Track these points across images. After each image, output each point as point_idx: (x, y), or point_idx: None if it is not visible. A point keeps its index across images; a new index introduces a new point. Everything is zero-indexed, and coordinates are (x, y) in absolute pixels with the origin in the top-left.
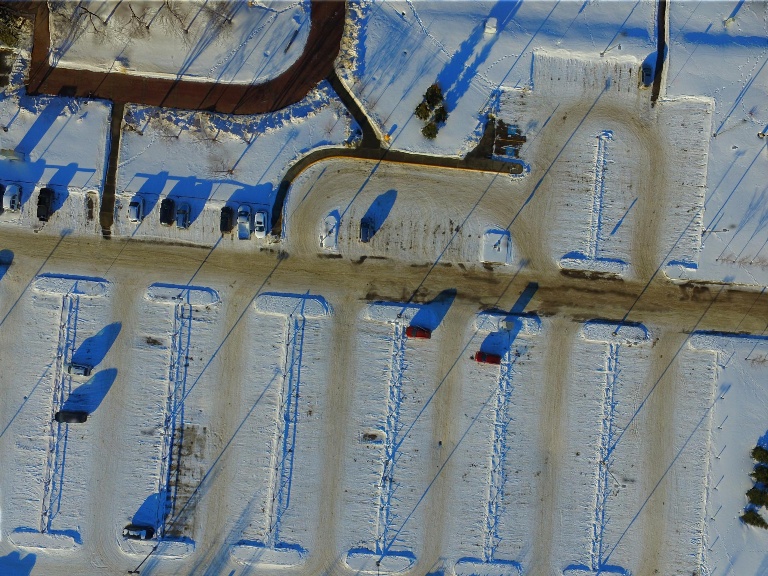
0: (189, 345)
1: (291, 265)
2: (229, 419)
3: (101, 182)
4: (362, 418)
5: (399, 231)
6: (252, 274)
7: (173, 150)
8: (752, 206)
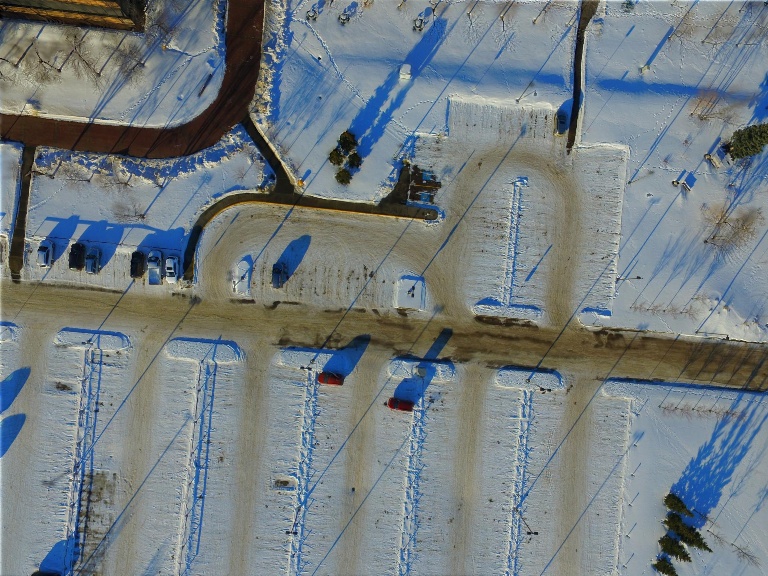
0: (99, 390)
1: (203, 310)
2: (139, 465)
3: (10, 226)
4: (274, 464)
5: (313, 276)
6: (164, 319)
7: (84, 194)
8: (667, 253)
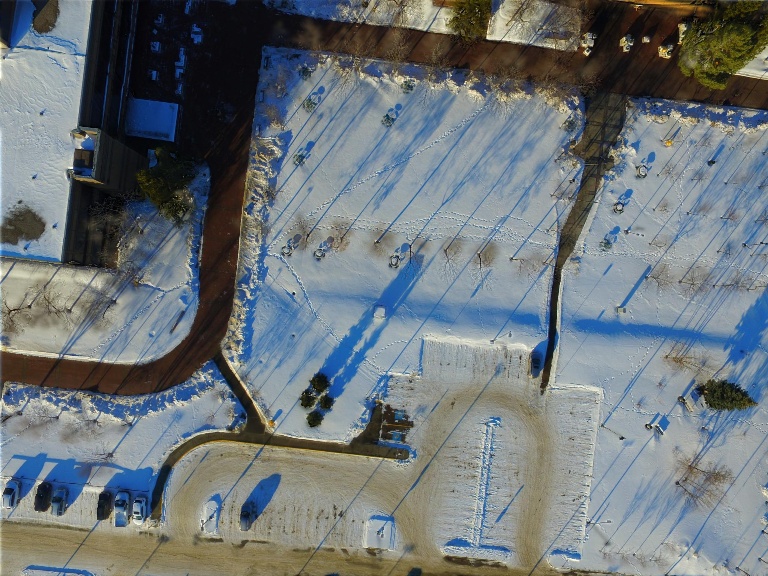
0: None
1: (170, 549)
2: None
3: None
4: None
5: (282, 515)
6: (130, 558)
7: (52, 431)
8: (638, 495)
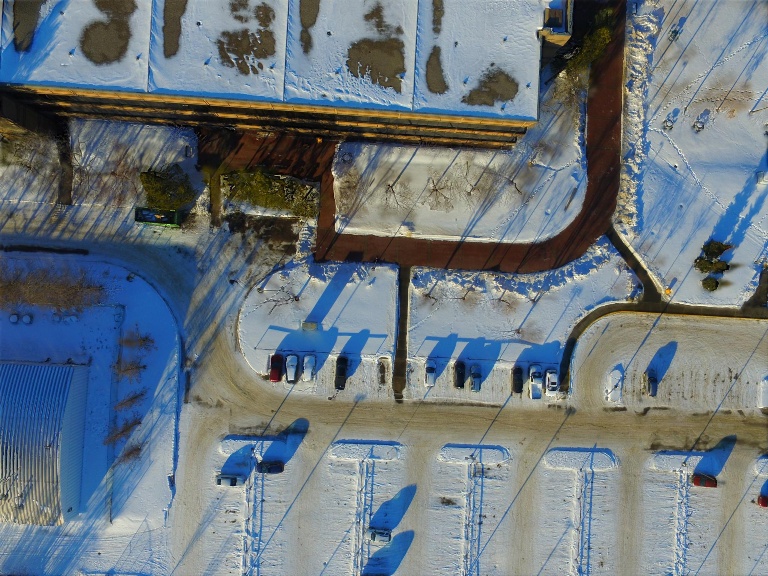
0: (482, 503)
1: (578, 420)
2: (523, 574)
3: (393, 347)
4: (651, 566)
5: (680, 381)
6: (541, 430)
7: (461, 312)
8: None
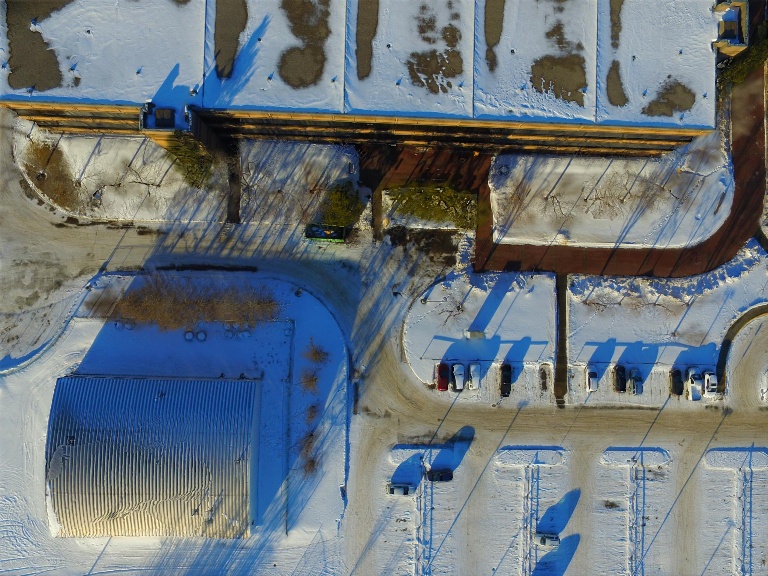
0: (644, 505)
1: (735, 420)
2: (687, 574)
3: (554, 354)
4: None
5: None
6: (699, 431)
7: (618, 317)
8: None
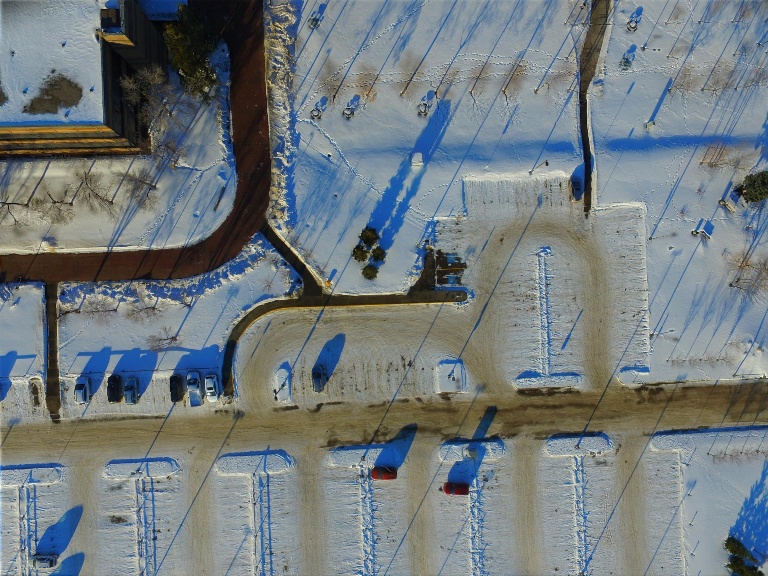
0: (155, 518)
1: (248, 423)
2: None
3: (43, 367)
4: (339, 566)
5: (352, 374)
6: (209, 438)
7: (113, 324)
8: (695, 302)
